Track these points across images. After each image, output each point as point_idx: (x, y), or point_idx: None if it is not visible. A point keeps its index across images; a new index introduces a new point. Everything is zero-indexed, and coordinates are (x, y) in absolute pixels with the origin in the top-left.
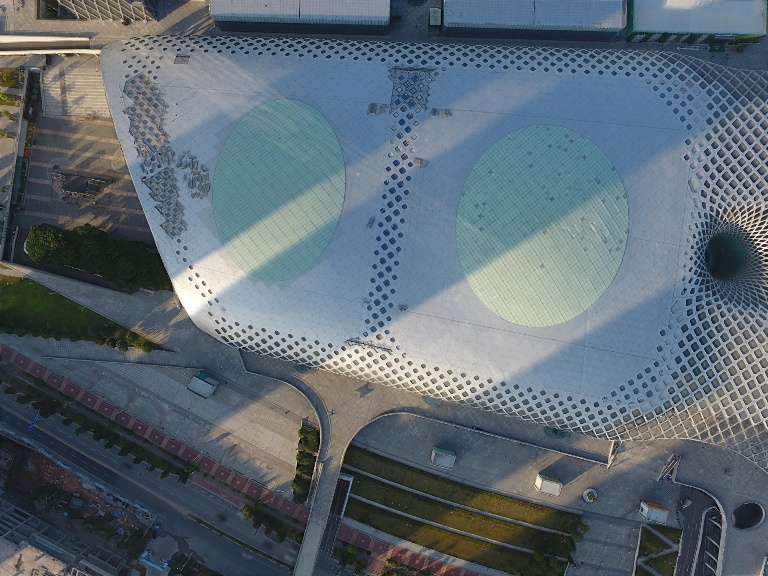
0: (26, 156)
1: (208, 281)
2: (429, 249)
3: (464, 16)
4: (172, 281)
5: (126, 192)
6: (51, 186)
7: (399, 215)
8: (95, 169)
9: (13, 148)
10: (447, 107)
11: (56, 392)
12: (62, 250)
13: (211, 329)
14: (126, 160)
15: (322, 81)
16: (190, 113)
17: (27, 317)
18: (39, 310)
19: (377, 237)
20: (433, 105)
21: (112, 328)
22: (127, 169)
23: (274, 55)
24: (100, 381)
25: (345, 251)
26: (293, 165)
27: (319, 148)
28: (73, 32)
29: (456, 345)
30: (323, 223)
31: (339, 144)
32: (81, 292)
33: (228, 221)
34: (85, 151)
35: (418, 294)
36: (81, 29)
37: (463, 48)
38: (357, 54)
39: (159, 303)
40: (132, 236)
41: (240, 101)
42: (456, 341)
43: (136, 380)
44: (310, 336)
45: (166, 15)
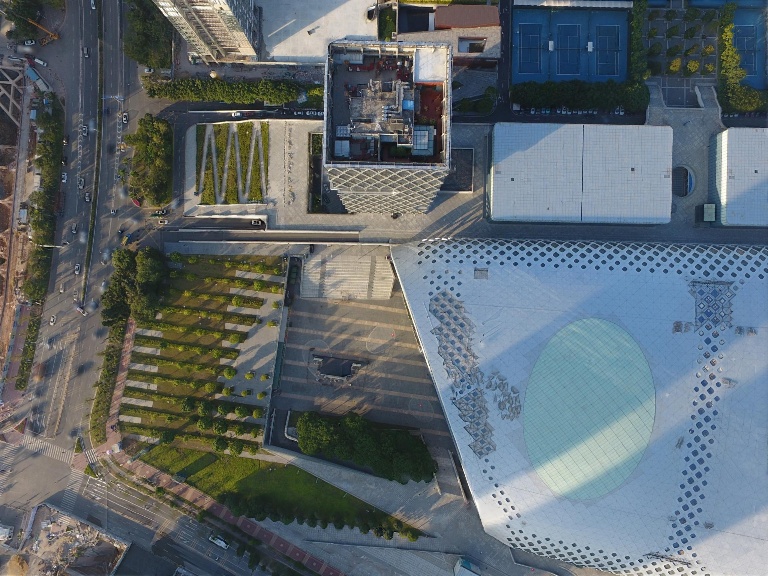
0: (284, 340)
1: (512, 498)
2: (738, 470)
3: (745, 217)
4: (475, 497)
5: (380, 373)
6: (307, 368)
7: (708, 436)
8: (350, 351)
9: (276, 335)
10: (751, 324)
11: (315, 575)
12: (337, 445)
13: (502, 536)
14: (436, 381)
15: (625, 298)
16: (497, 333)
17: (289, 502)
18: (301, 495)
19: (685, 457)
20: (737, 322)
21: (374, 514)
22: (382, 351)
23: (571, 268)
24: (359, 564)
25: (653, 471)
26: (604, 388)
27: (629, 370)
28: (343, 225)
29: (759, 561)
30: (634, 445)
31: (648, 365)
32: (343, 478)
33: (539, 443)
34: (340, 333)
35: (725, 513)
36: (350, 222)
37: (752, 254)
38: (652, 265)
39: (420, 489)
40: (386, 417)
41: (546, 320)
42: (760, 558)
43: (396, 564)
44: (608, 549)
45: (434, 208)
